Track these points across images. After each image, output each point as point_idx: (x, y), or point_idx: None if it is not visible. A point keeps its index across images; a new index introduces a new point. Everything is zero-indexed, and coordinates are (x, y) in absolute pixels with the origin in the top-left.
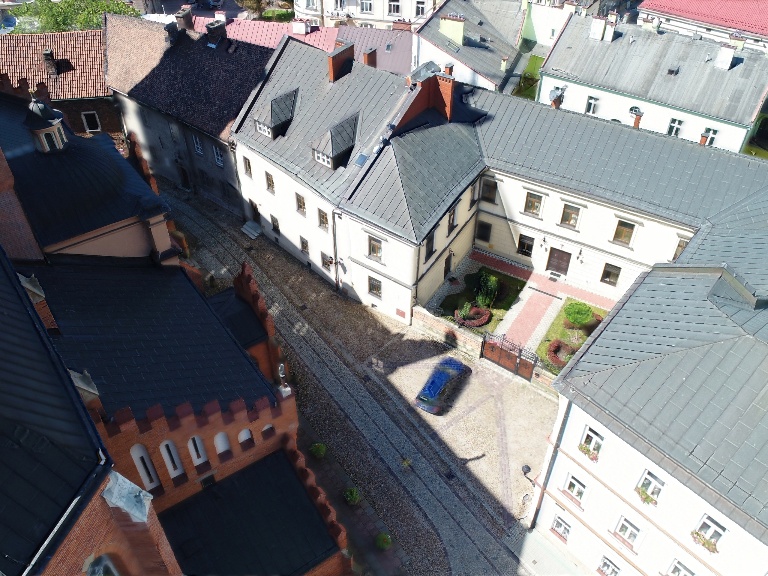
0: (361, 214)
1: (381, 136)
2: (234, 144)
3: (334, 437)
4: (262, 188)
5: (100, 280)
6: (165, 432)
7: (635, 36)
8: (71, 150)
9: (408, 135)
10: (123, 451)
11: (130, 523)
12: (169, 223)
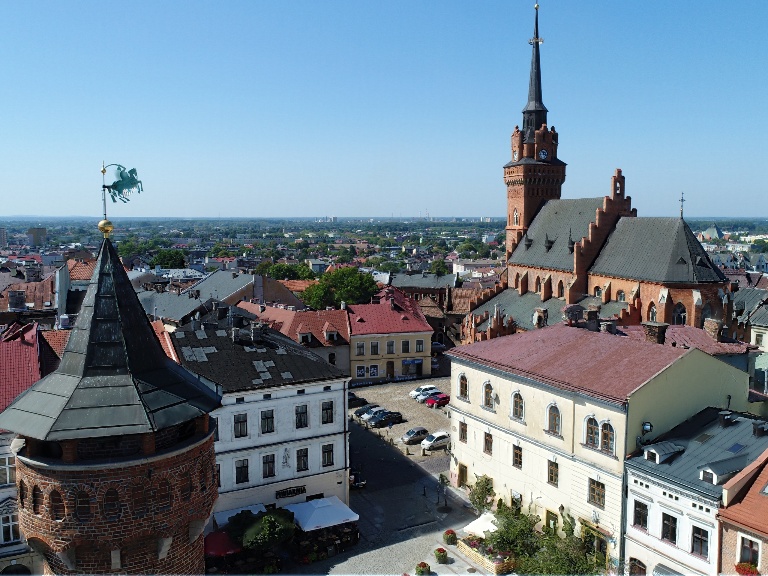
0: None
1: (759, 302)
2: None
3: None
4: None
5: None
6: None
7: None
8: None
9: None
10: None
11: (729, 300)
12: None
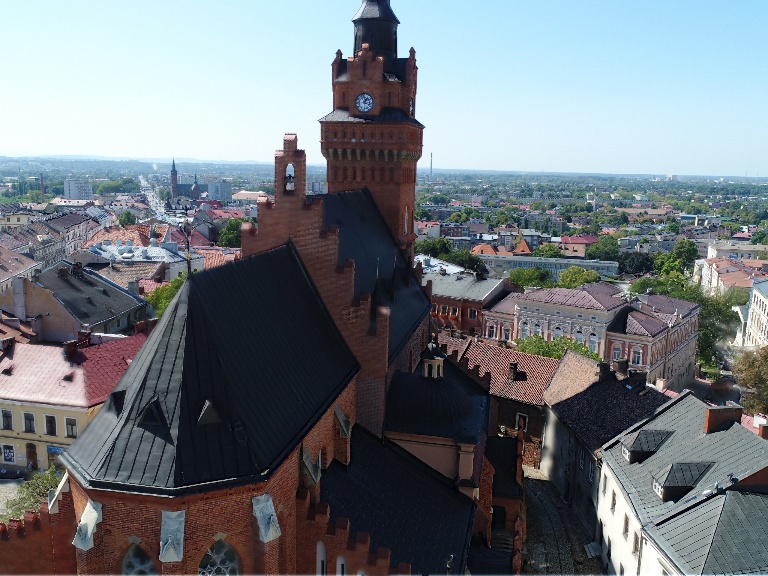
0: (659, 541)
1: (716, 482)
2: (602, 461)
3: None
4: (609, 507)
5: (406, 471)
6: (343, 547)
7: None
8: (441, 382)
9: (753, 496)
10: (311, 540)
11: (258, 539)
12: (518, 501)
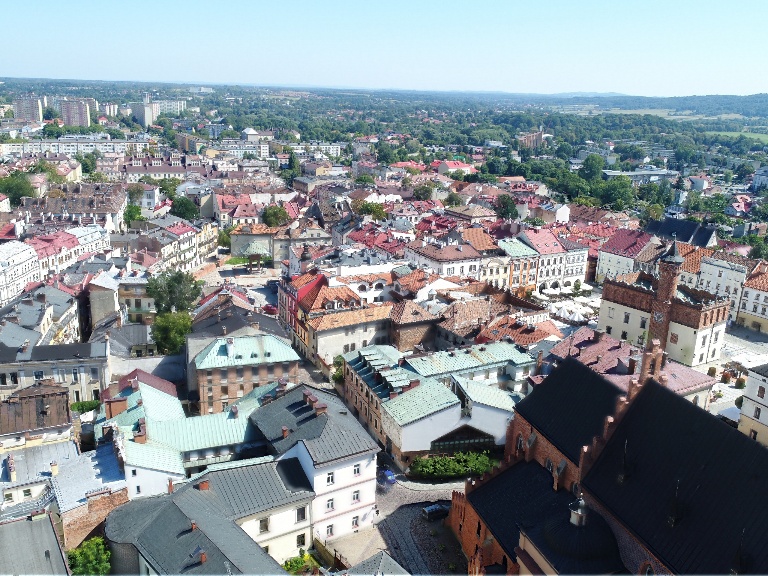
0: (408, 574)
1: None
2: None
3: (444, 573)
4: None
5: None
6: None
7: None
8: None
9: None
10: None
11: None
12: None
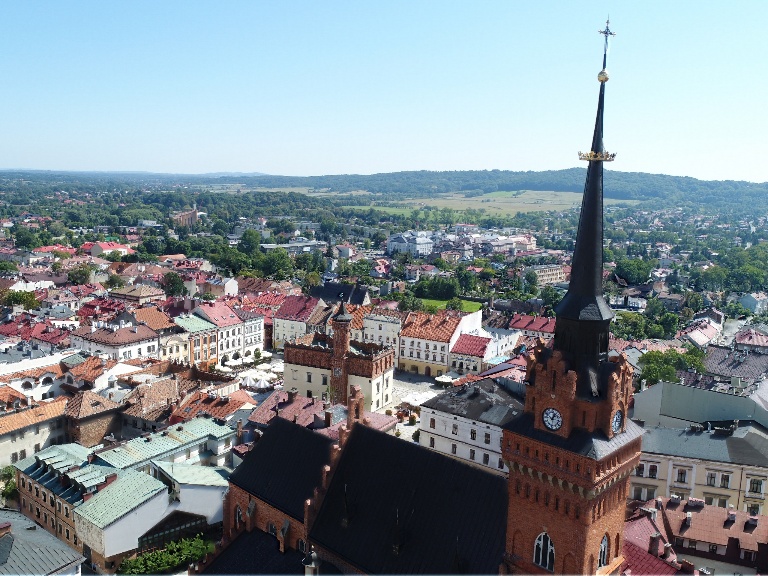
0: None
1: None
2: None
3: None
4: None
5: None
6: None
7: None
8: None
9: None
10: None
11: None
12: None
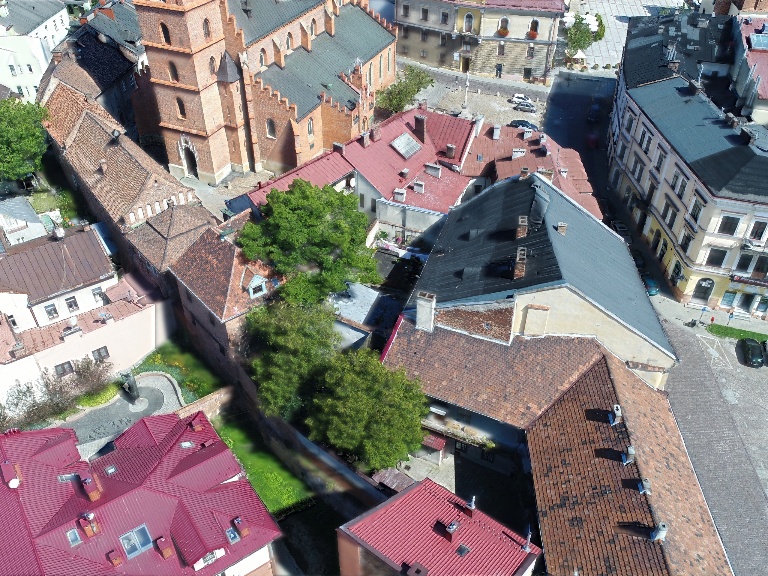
0: None
1: None
2: None
3: None
4: None
5: None
6: None
7: (7, 8)
8: None
9: None
10: None
11: None
12: None
